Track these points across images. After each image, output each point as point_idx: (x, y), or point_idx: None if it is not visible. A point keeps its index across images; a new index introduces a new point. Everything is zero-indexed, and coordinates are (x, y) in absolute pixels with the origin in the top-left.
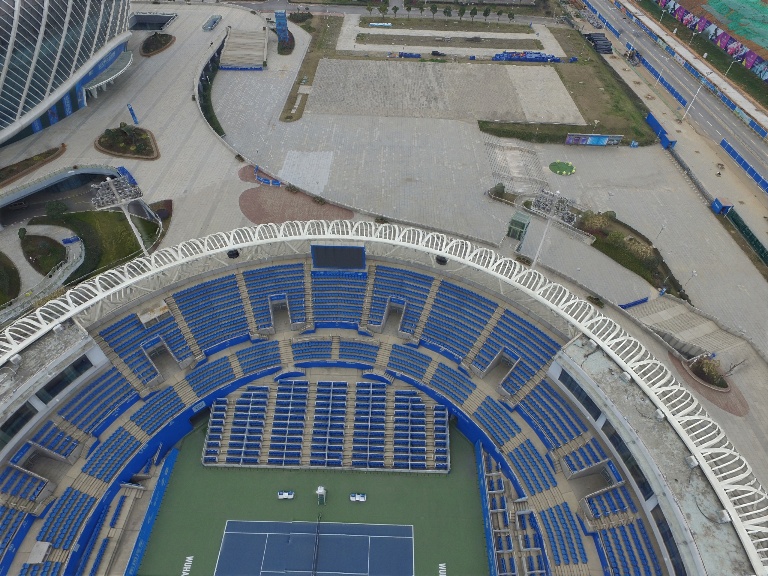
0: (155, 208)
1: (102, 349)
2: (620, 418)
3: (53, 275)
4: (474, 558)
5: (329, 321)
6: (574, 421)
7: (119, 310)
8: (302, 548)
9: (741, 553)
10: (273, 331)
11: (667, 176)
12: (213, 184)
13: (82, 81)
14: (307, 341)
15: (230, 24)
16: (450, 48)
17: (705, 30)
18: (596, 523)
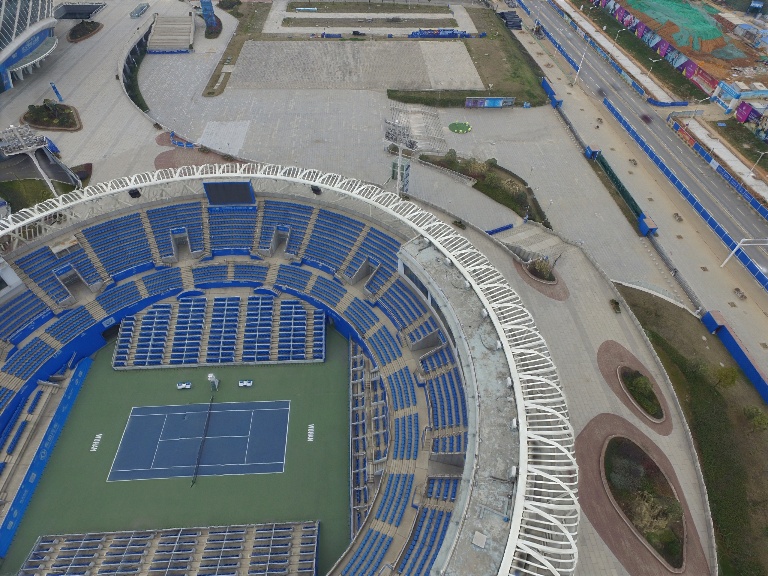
0: (76, 171)
1: (18, 275)
2: (438, 290)
3: None
4: (338, 419)
5: (224, 249)
6: (418, 307)
7: (32, 243)
8: (195, 422)
9: (506, 367)
10: (175, 260)
11: (552, 130)
12: (131, 149)
13: (6, 63)
14: (206, 266)
15: (158, 11)
16: (370, 28)
17: (606, 6)
18: (426, 376)
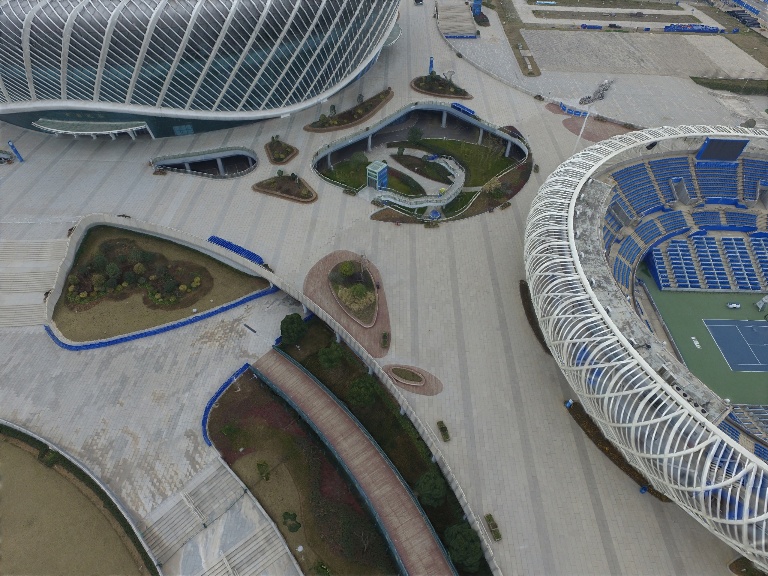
0: (504, 131)
1: None
2: None
3: (456, 176)
4: None
5: (716, 197)
6: None
7: None
8: (766, 333)
9: None
10: (675, 204)
11: None
12: (534, 116)
13: None
14: (702, 211)
15: None
16: (620, 22)
17: None
18: None
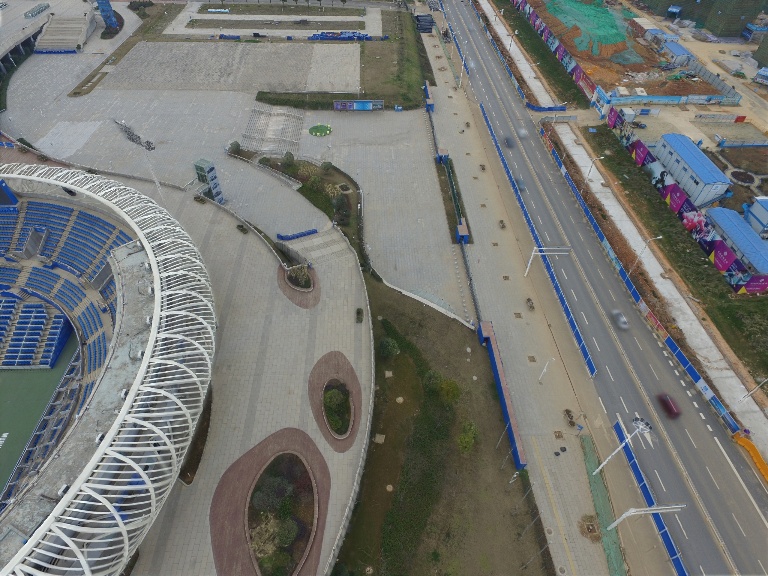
0: None
1: None
2: None
3: None
4: None
5: None
6: None
7: None
8: None
9: None
10: None
11: (413, 134)
12: None
13: None
14: None
15: (55, 11)
16: (274, 30)
17: (524, 10)
18: None
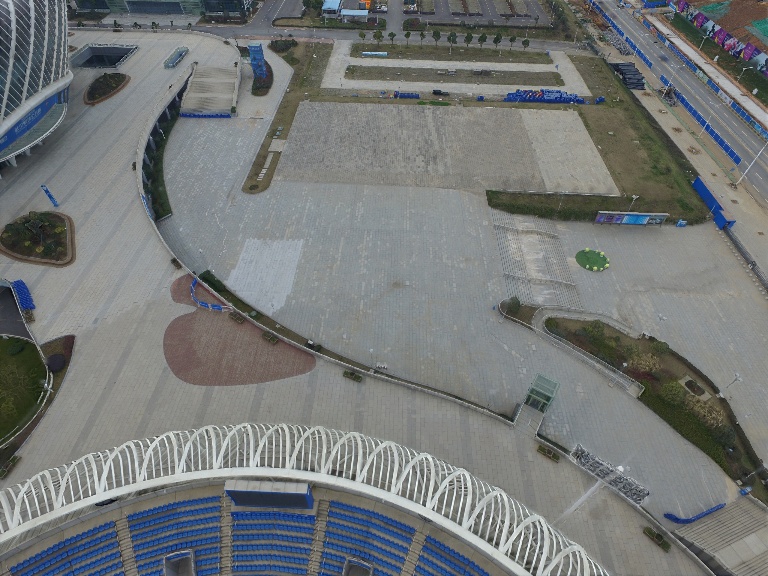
0: (50, 350)
1: None
2: None
3: None
4: None
5: None
6: None
7: None
8: None
9: None
10: None
11: (727, 272)
12: (134, 307)
13: None
14: None
15: (197, 58)
16: (454, 84)
17: (753, 59)
18: None
